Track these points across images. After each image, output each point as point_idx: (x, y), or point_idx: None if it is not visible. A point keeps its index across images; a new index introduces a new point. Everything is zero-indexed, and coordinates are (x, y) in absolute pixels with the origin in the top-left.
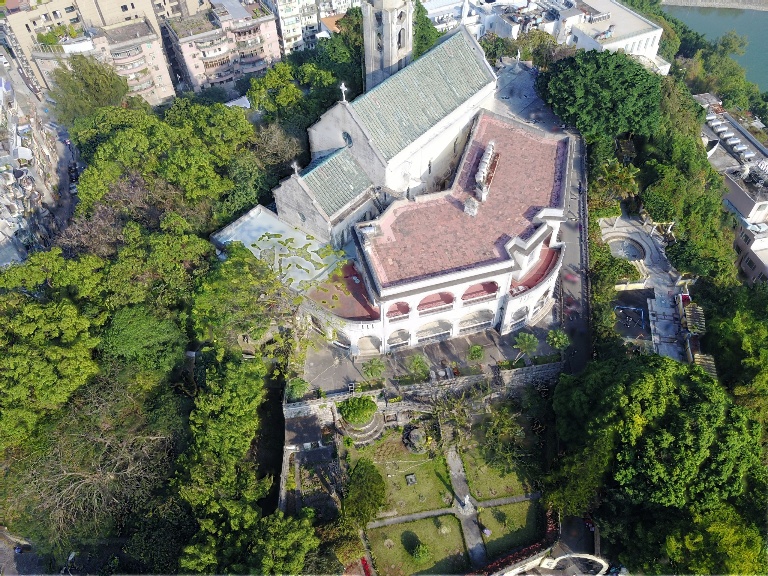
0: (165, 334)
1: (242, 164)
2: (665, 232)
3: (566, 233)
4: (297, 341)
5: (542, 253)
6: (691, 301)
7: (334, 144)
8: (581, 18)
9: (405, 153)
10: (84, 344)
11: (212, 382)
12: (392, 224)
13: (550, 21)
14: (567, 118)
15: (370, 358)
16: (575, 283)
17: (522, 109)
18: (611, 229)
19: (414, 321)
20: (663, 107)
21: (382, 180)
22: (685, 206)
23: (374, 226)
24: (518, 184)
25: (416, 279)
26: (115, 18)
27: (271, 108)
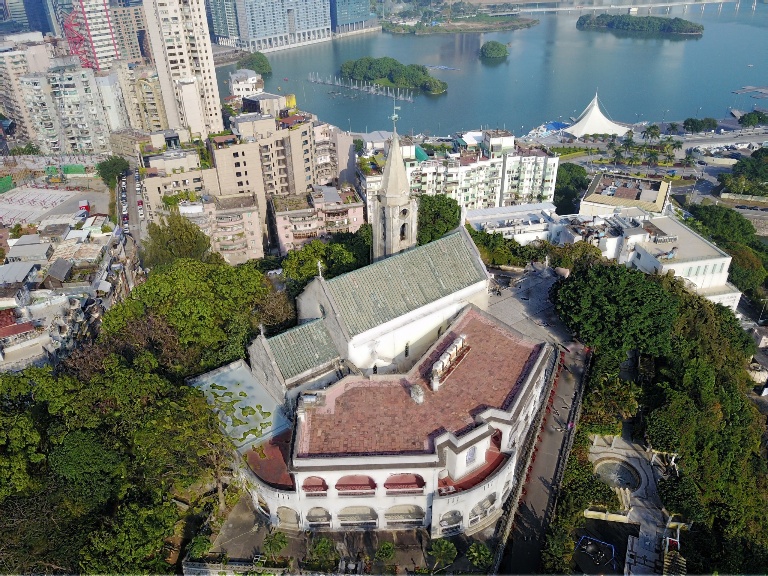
0: (109, 464)
1: (237, 320)
2: (668, 463)
3: (546, 442)
4: (222, 497)
5: (491, 456)
6: (679, 549)
7: (313, 314)
8: (646, 237)
9: (375, 332)
10: (28, 457)
11: (113, 519)
12: (338, 397)
13: (614, 236)
14: (572, 326)
15: (288, 532)
16: (541, 499)
17: (538, 311)
18: (608, 449)
19: (333, 501)
20: (696, 331)
21: (346, 354)
22: (699, 439)
23: (319, 396)
24: (477, 380)
25: (335, 455)
26: (229, 190)
27: (294, 277)
